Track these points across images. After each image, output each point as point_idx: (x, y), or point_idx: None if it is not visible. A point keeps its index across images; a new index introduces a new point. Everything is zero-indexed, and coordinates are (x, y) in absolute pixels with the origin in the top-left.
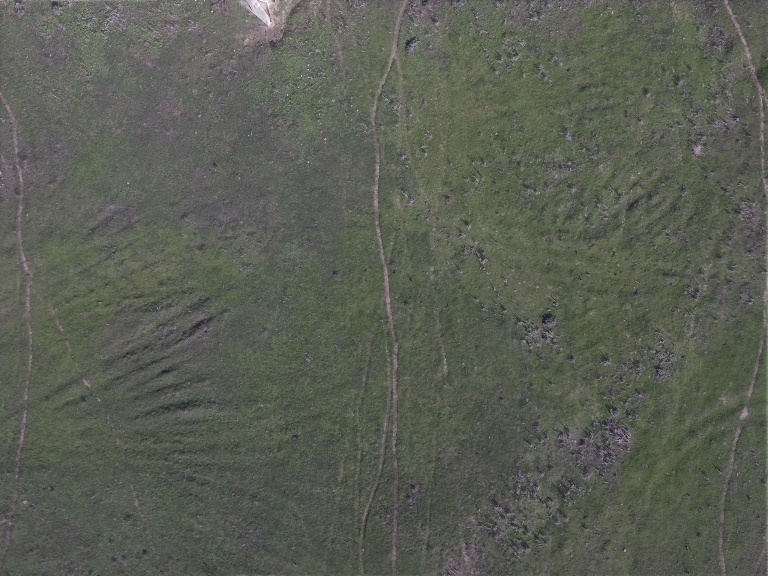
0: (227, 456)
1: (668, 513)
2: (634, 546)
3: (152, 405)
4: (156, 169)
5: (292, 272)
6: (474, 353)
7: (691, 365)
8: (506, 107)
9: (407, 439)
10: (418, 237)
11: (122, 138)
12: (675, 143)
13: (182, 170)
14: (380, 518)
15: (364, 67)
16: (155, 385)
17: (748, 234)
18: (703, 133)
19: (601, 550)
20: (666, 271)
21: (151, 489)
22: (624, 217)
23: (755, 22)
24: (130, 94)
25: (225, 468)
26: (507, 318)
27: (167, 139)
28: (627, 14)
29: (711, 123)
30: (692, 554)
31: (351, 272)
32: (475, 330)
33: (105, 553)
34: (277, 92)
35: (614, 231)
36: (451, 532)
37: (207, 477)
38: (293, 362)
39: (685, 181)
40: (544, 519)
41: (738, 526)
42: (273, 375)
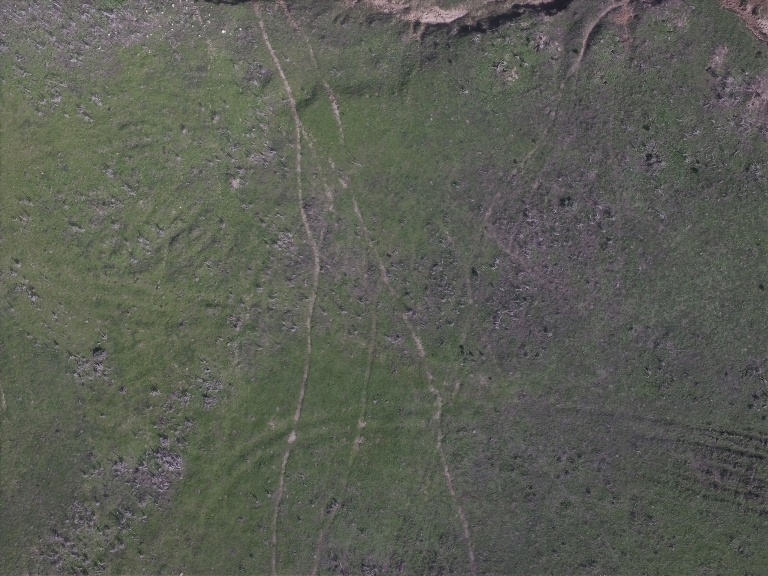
0: None
1: (222, 536)
2: (191, 569)
3: None
4: None
5: None
6: (30, 388)
7: (239, 392)
8: (51, 147)
9: None
10: None
11: None
12: (214, 177)
13: None
14: None
15: None
16: None
17: (288, 263)
18: (242, 166)
19: (157, 575)
20: (210, 302)
21: None
22: (167, 251)
23: (294, 56)
24: None
25: None
26: (60, 353)
27: None
28: (163, 53)
29: (249, 156)
30: (246, 575)
31: None
32: (30, 365)
33: None
34: None
35: (156, 265)
36: (15, 562)
37: None
38: None
39: (225, 214)
40: (102, 547)
41: (290, 546)
42: None
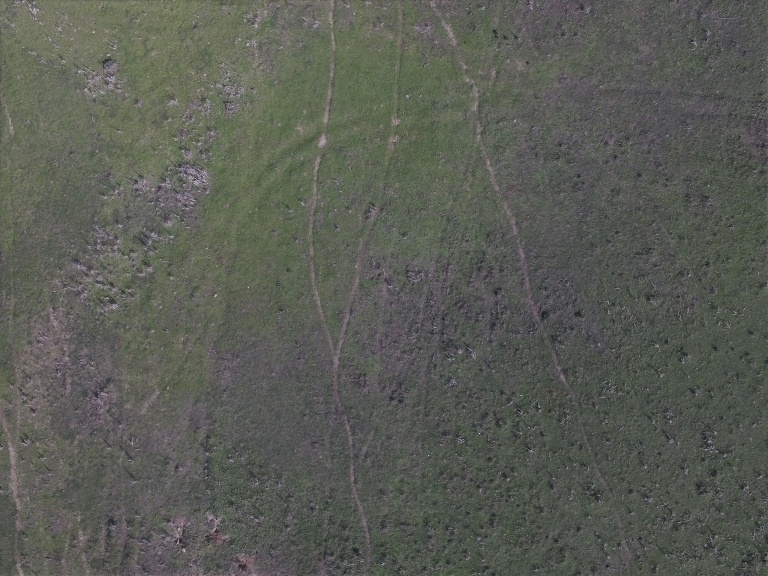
0: None
1: (256, 252)
2: (225, 290)
3: None
4: None
5: None
6: (38, 109)
7: (262, 97)
8: None
9: None
10: None
11: None
12: None
13: None
14: None
15: None
16: None
17: None
18: None
19: (190, 297)
20: (224, 1)
21: None
22: None
23: None
24: None
25: None
26: (67, 69)
27: None
28: None
29: None
30: (284, 291)
31: None
32: (36, 85)
33: None
34: None
35: None
36: (36, 298)
37: None
38: None
39: None
40: (129, 273)
41: (329, 258)
42: None
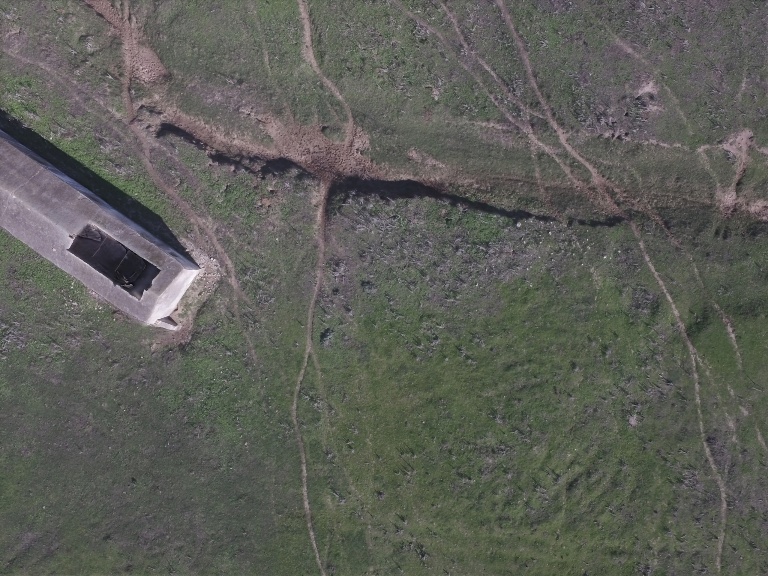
0: None
1: None
2: None
3: None
4: (72, 489)
5: None
6: None
7: None
8: (431, 393)
9: None
10: (353, 537)
11: (32, 461)
12: (609, 415)
13: (99, 487)
14: None
15: (279, 364)
16: None
17: (694, 501)
18: (637, 401)
19: None
20: (614, 549)
21: None
22: (565, 497)
23: (679, 277)
24: (36, 413)
25: None
26: None
27: (80, 458)
28: (546, 286)
29: (644, 390)
30: None
31: None
32: None
33: None
34: (191, 400)
35: (556, 514)
36: None
37: None
38: None
39: (624, 453)
40: None
41: None
42: None
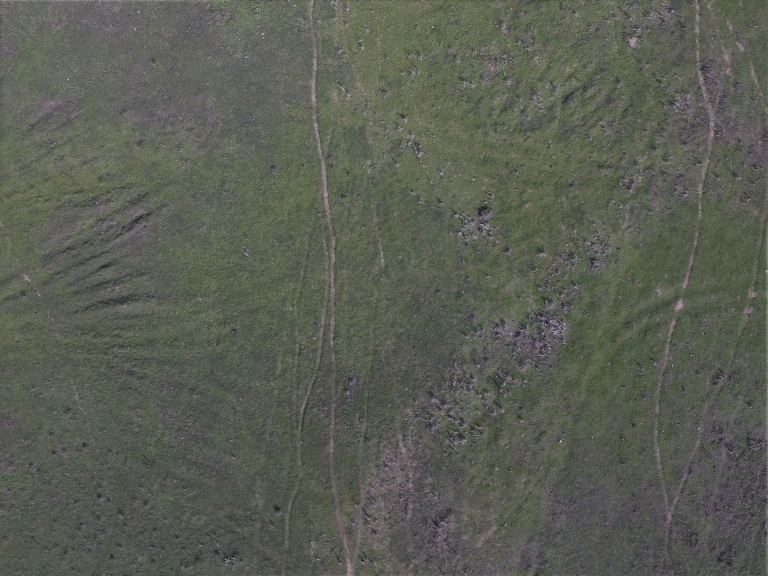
0: (166, 350)
1: (603, 404)
2: (570, 437)
3: (92, 299)
4: (96, 65)
5: (230, 167)
6: (411, 246)
7: (626, 257)
8: (442, 0)
9: (345, 332)
10: (355, 131)
11: (62, 34)
12: (610, 35)
13: (122, 66)
14: (318, 411)
15: None
16: (95, 280)
17: (683, 126)
18: (638, 26)
19: (537, 441)
20: (601, 163)
21: (91, 383)
22: (559, 109)
23: None
24: None
25: (164, 362)
26: (443, 211)
27: (106, 35)
28: None
29: (646, 15)
30: (627, 445)
31: (289, 166)
32: (412, 223)
33: (45, 446)
34: None
35: (549, 123)
36: (388, 424)
37: (146, 371)
38: (232, 256)
39: (620, 73)
40: (480, 411)
41: (673, 417)
42: (212, 269)
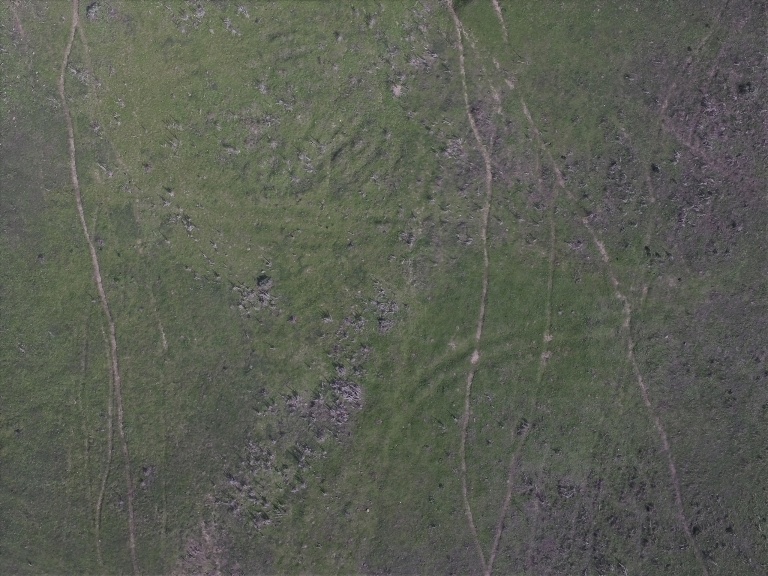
0: None
1: (408, 467)
2: (377, 505)
3: None
4: None
5: None
6: (192, 324)
7: (415, 313)
8: (197, 66)
9: (134, 421)
10: (121, 210)
11: None
12: (374, 86)
13: None
14: (114, 506)
15: (46, 39)
16: None
17: (458, 172)
18: (402, 73)
19: (343, 513)
20: (379, 219)
21: None
22: (329, 167)
23: None
24: None
25: None
26: (222, 285)
27: None
28: None
29: (409, 62)
30: (436, 506)
31: (57, 254)
32: (190, 300)
33: None
34: None
35: (320, 183)
36: (189, 512)
37: None
38: (7, 354)
39: (388, 124)
40: (281, 488)
41: (481, 473)
42: None
